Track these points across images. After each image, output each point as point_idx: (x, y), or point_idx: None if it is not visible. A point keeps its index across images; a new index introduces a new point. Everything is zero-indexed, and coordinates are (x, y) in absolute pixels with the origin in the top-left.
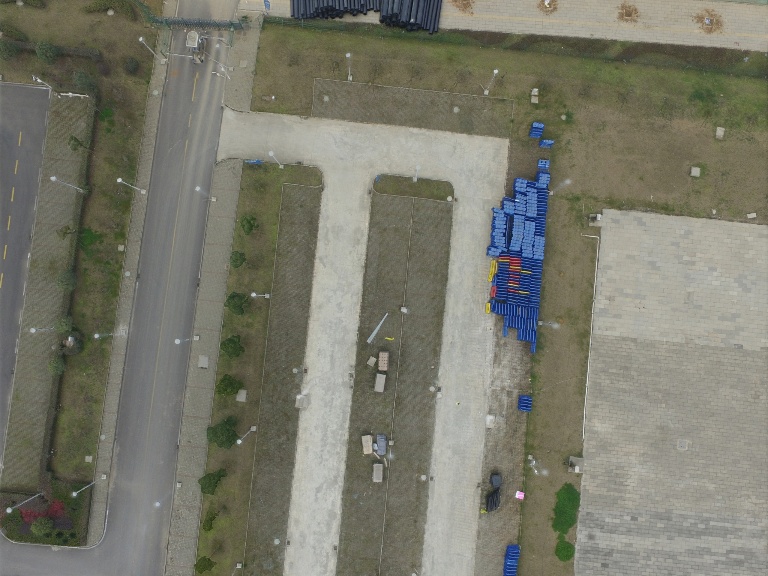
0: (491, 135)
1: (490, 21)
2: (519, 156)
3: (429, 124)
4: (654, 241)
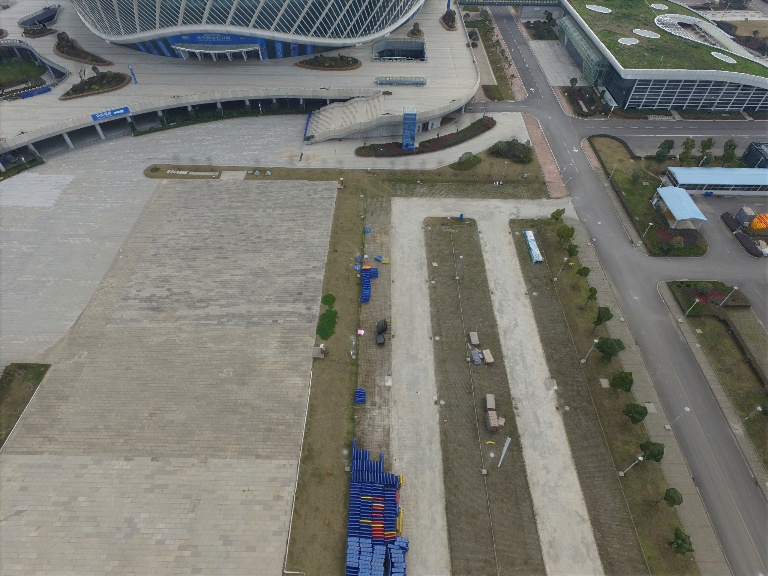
0: None
1: None
2: None
3: None
4: (221, 573)
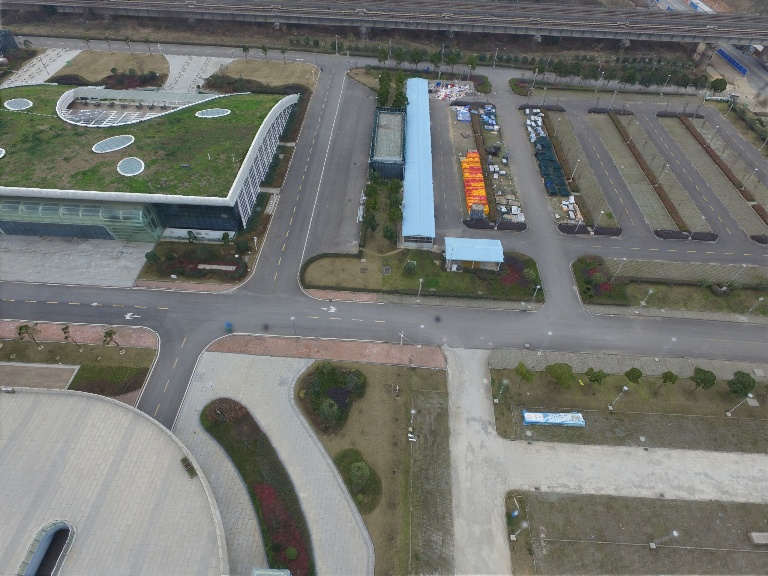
0: None
1: None
2: None
3: None
4: None
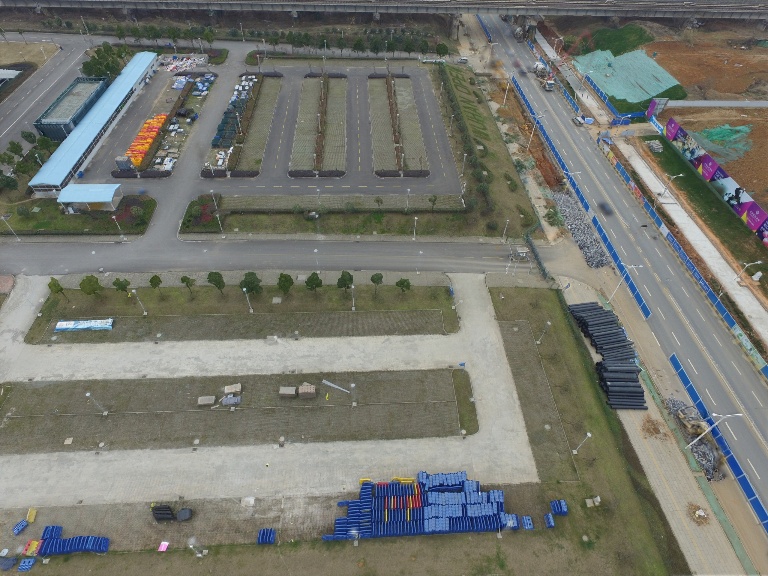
0: (537, 463)
1: (648, 456)
2: (527, 495)
3: (525, 406)
4: None
